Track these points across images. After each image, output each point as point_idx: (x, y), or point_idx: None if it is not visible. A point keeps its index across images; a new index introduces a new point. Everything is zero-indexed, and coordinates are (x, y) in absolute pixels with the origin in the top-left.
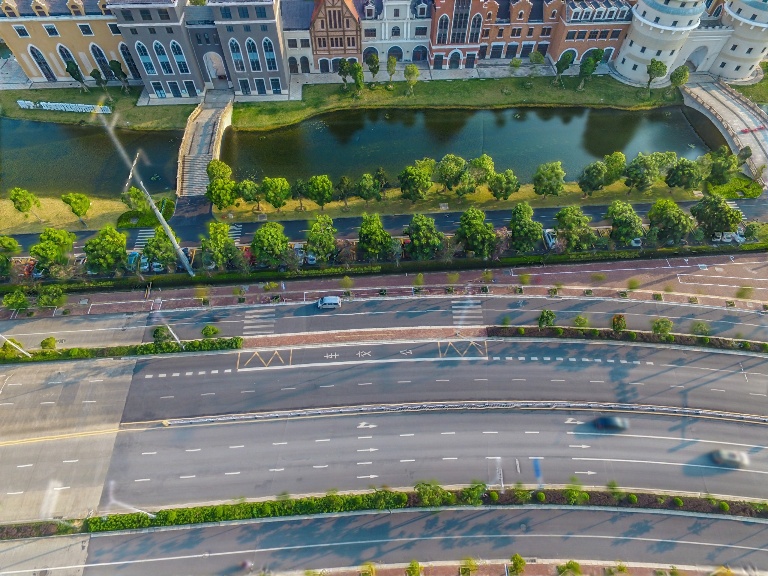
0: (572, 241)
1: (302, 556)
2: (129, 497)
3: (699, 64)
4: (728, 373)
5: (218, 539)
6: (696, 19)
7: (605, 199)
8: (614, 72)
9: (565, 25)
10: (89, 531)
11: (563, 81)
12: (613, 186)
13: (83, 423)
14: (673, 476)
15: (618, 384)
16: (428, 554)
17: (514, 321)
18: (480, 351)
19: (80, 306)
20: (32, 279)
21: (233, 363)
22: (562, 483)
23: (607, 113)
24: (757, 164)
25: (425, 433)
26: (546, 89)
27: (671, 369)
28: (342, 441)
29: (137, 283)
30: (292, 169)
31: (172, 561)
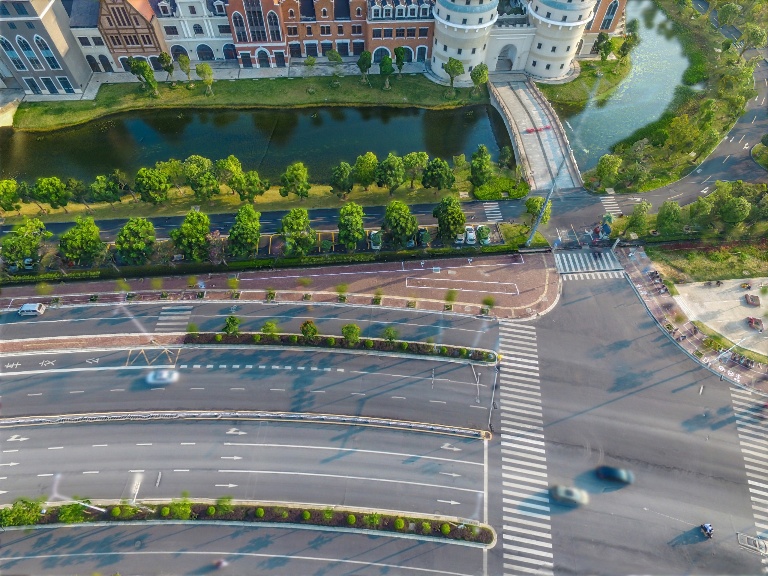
0: (287, 244)
1: None
2: None
3: (513, 63)
4: (416, 380)
5: None
6: (487, 17)
7: (365, 201)
8: (428, 71)
9: (367, 23)
10: None
11: (372, 80)
12: (380, 187)
13: None
14: (315, 488)
15: (298, 392)
16: (23, 574)
17: (218, 327)
18: (170, 359)
19: None
20: None
21: None
22: (197, 497)
23: (408, 112)
24: (532, 164)
25: (76, 446)
26: (353, 88)
27: (360, 376)
28: None
29: None
30: (59, 171)
31: None
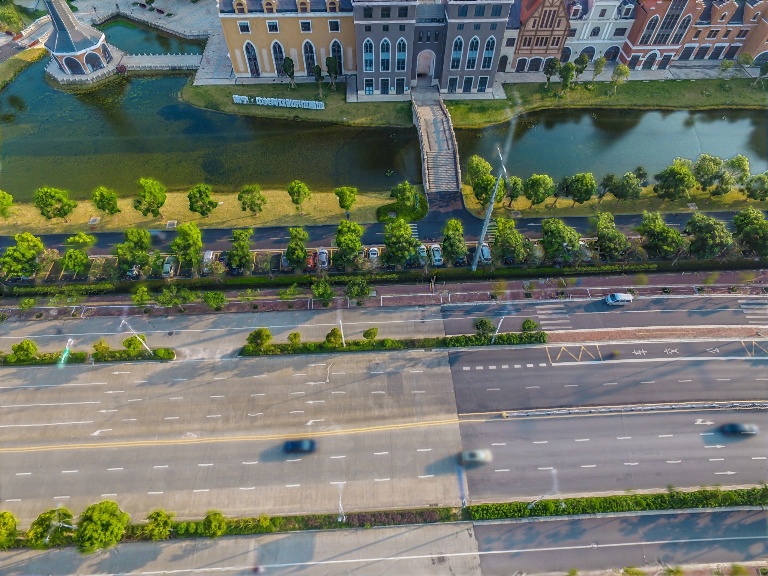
0: None
1: (691, 550)
2: (496, 487)
3: None
4: None
5: (600, 531)
6: None
7: None
8: None
9: None
10: (473, 519)
11: (761, 83)
12: None
13: (421, 413)
14: None
15: None
16: None
17: None
18: None
19: (371, 298)
20: (318, 270)
21: (545, 357)
22: None
23: None
24: None
25: (766, 431)
26: (745, 91)
27: None
28: (686, 437)
29: (422, 276)
30: (520, 167)
31: (561, 551)
